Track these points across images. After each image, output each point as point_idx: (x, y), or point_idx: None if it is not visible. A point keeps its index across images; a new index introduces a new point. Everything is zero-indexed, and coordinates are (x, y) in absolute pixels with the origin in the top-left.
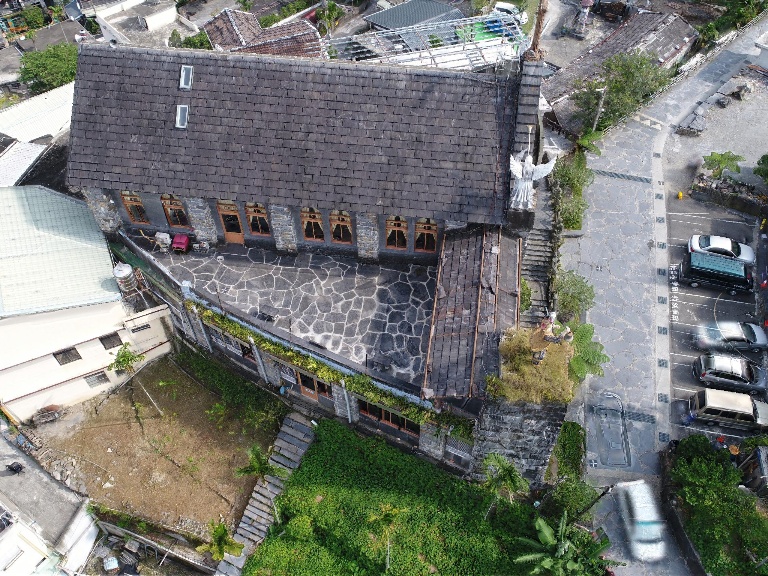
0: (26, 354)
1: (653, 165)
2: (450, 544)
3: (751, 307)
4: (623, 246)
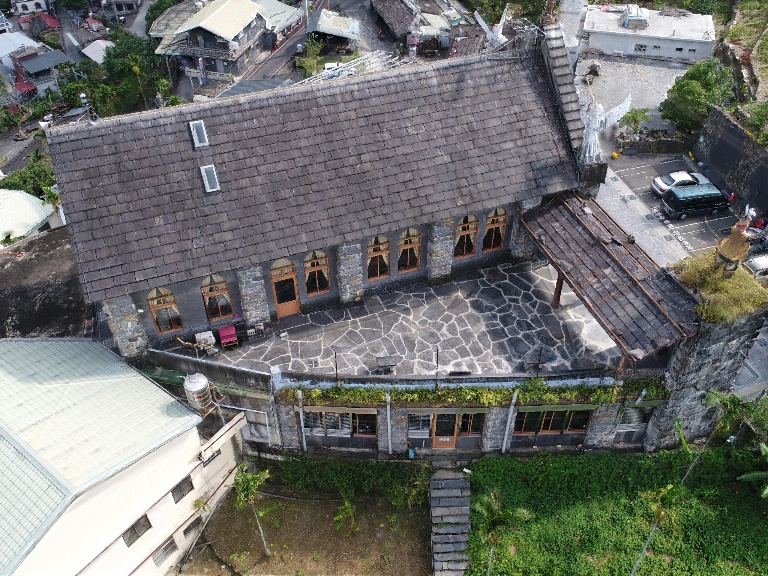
0: (94, 545)
1: None
2: (665, 526)
3: (734, 218)
4: (605, 208)
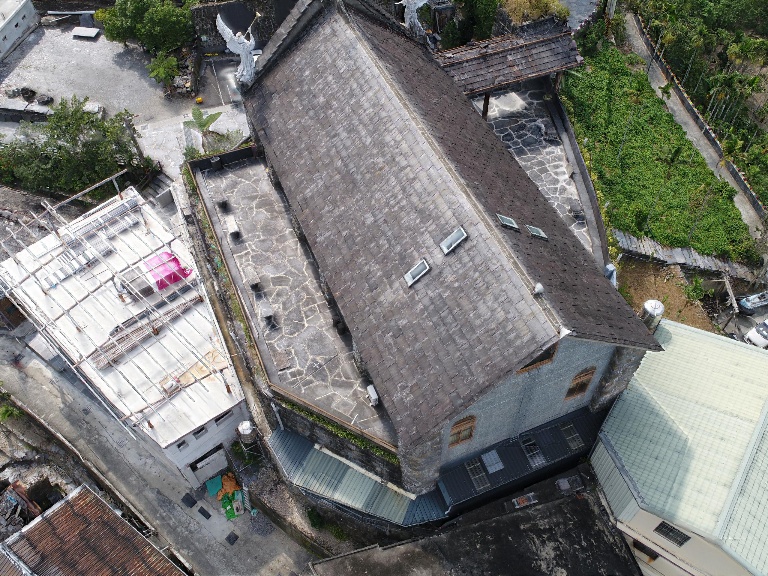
0: None
1: (162, 126)
2: None
3: None
4: None
